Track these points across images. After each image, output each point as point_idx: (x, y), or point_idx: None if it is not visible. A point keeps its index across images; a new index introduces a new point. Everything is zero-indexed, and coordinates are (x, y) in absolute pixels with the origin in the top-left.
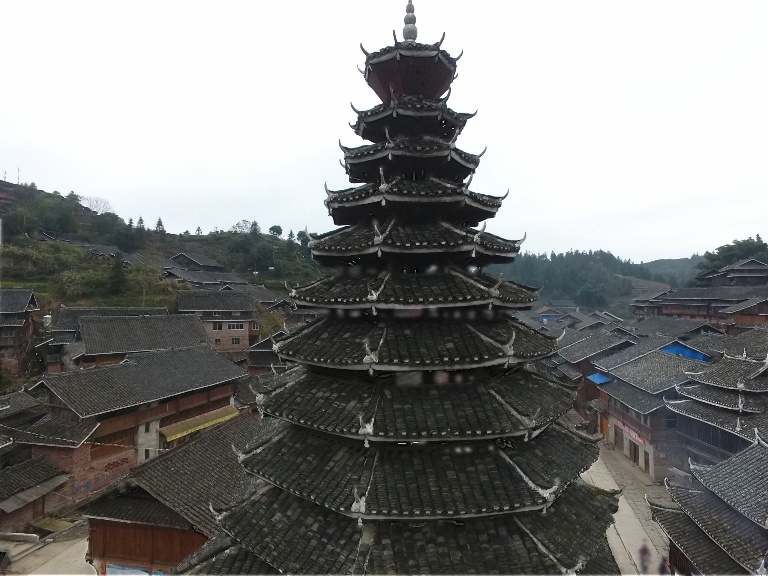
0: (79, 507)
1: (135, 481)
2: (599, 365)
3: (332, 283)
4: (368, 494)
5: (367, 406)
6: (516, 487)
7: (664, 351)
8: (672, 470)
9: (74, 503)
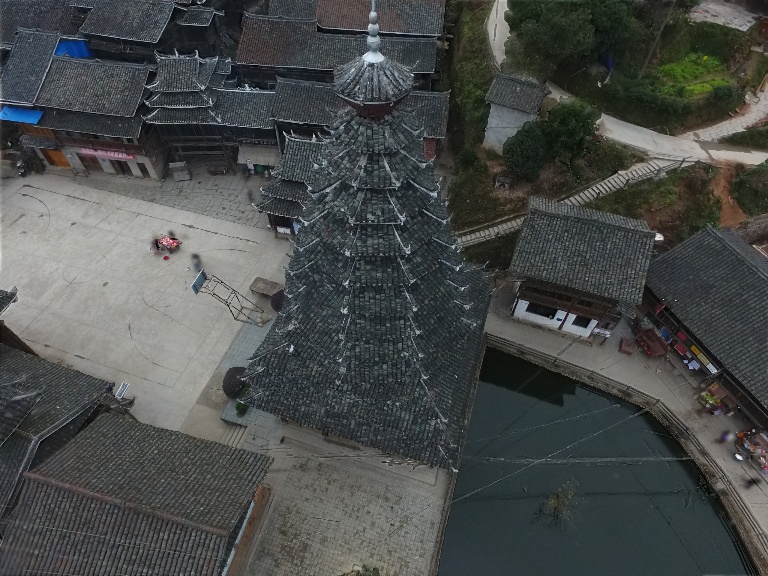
0: None
1: None
2: (7, 99)
3: (409, 258)
4: None
5: (449, 283)
6: None
7: (68, 57)
8: (173, 166)
9: None
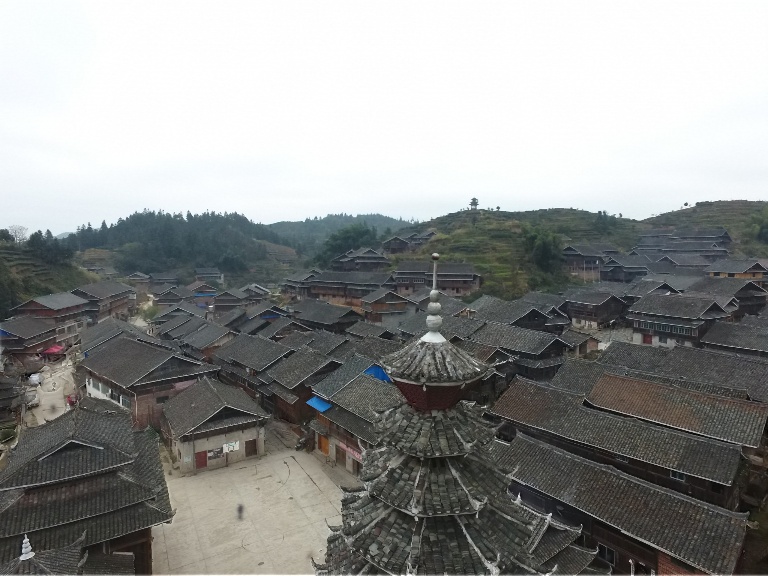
0: None
1: None
2: (318, 392)
3: None
4: None
5: None
6: None
7: None
8: None
9: None
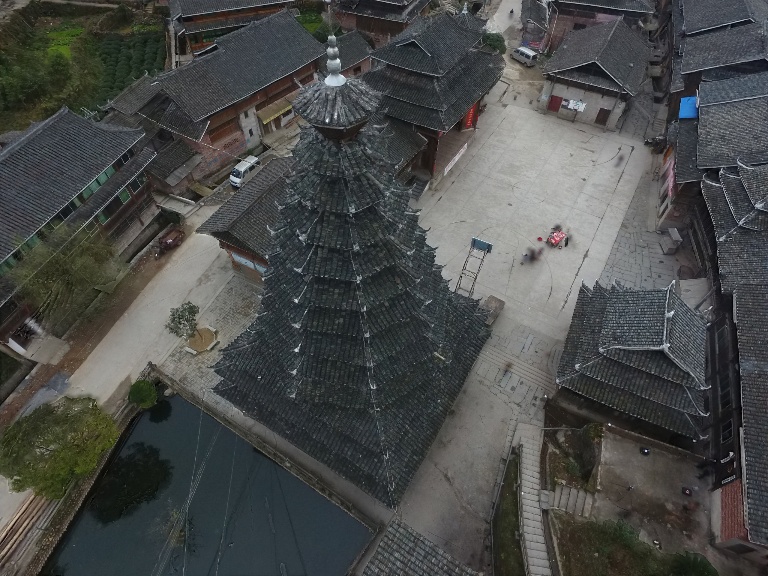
0: (206, 232)
1: (230, 232)
2: (699, 92)
3: None
4: (299, 367)
5: None
6: (363, 378)
7: None
8: (671, 231)
9: (210, 172)
